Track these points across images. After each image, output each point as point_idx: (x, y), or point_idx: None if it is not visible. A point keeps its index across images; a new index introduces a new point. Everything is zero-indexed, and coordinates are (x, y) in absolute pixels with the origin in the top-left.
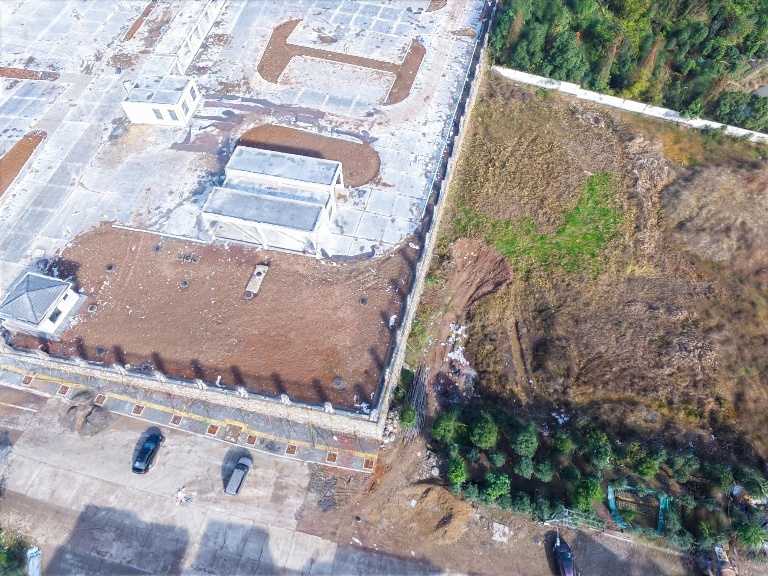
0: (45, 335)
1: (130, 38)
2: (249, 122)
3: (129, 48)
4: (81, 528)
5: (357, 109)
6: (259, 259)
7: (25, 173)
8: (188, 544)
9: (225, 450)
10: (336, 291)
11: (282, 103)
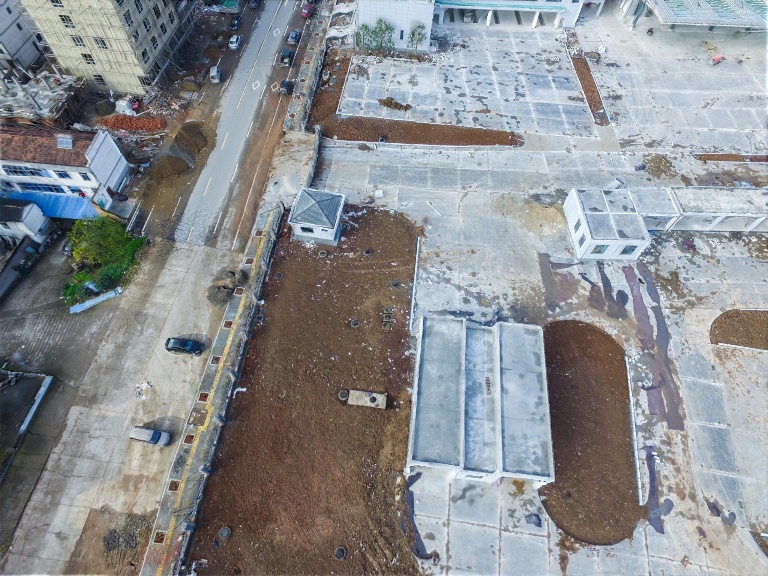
0: (292, 230)
1: (702, 159)
2: (617, 326)
3: (684, 164)
4: (130, 316)
5: (717, 483)
6: (397, 394)
7: (468, 150)
8: (99, 405)
9: (182, 415)
10: (355, 507)
11: (674, 360)
